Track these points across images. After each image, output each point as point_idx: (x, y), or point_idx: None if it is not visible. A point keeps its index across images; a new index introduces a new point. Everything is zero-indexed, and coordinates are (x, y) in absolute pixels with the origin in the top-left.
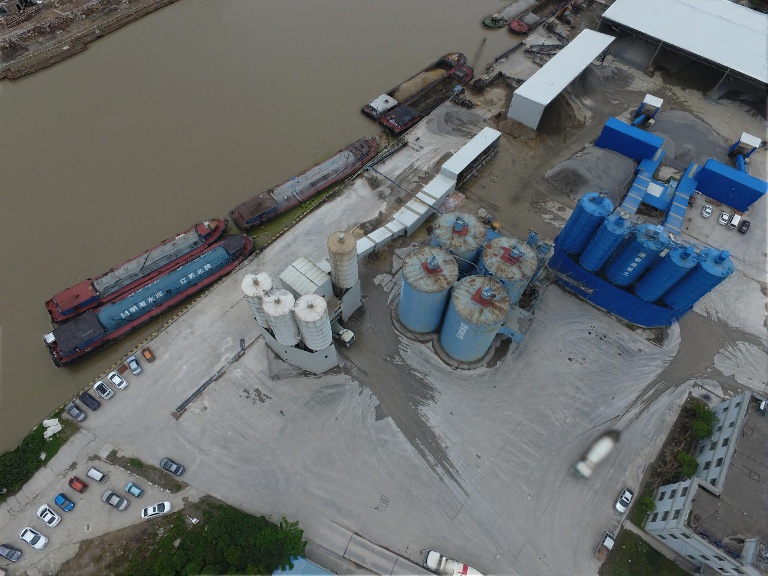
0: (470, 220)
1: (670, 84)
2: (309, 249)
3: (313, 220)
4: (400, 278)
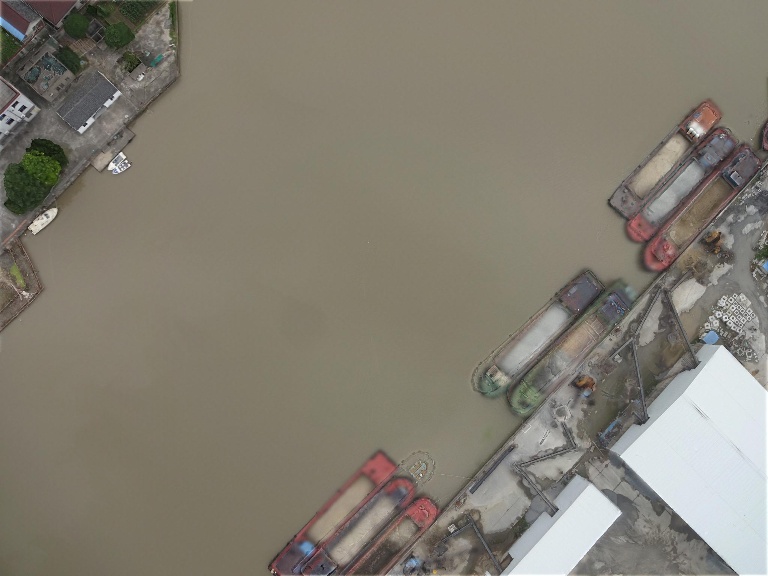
0: None
1: (677, 530)
2: None
3: None
4: None
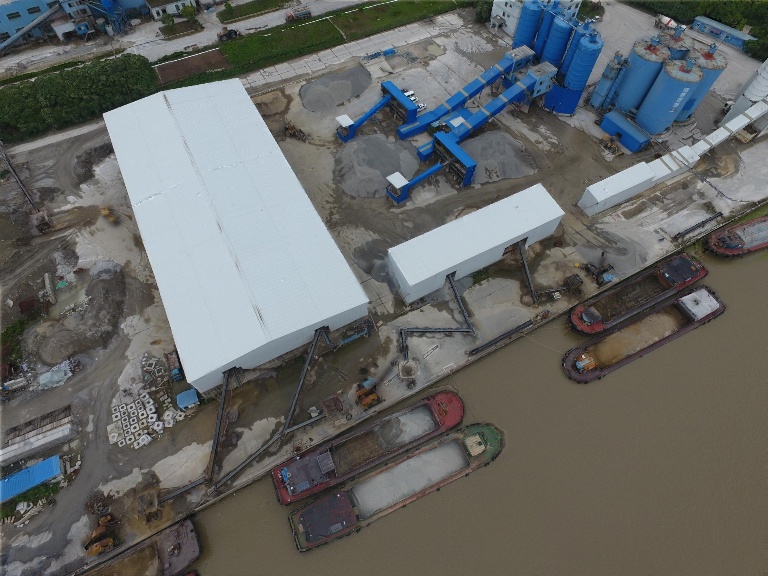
0: (676, 73)
1: None
2: (765, 170)
3: (766, 191)
4: (687, 133)
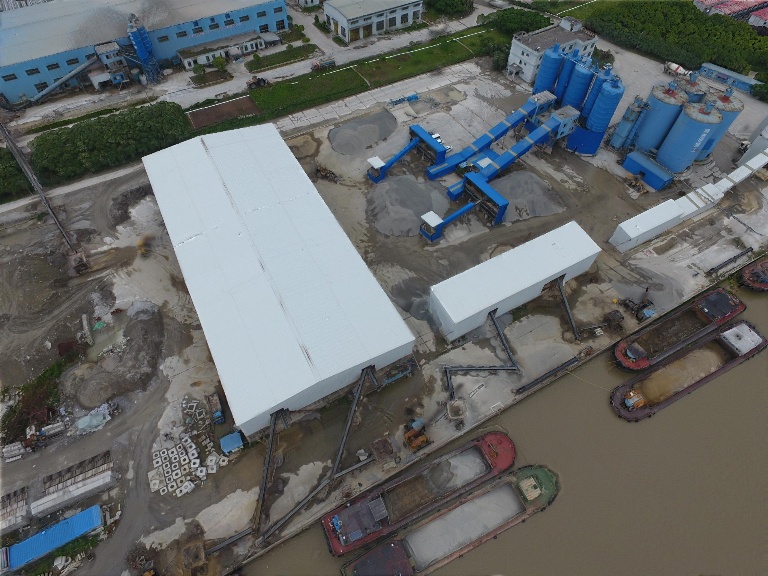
0: (697, 115)
1: None
2: None
3: None
4: (707, 172)
